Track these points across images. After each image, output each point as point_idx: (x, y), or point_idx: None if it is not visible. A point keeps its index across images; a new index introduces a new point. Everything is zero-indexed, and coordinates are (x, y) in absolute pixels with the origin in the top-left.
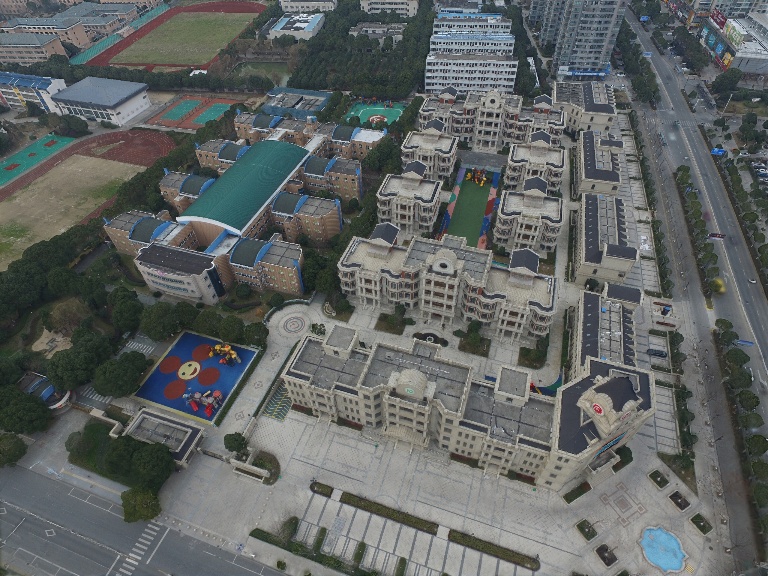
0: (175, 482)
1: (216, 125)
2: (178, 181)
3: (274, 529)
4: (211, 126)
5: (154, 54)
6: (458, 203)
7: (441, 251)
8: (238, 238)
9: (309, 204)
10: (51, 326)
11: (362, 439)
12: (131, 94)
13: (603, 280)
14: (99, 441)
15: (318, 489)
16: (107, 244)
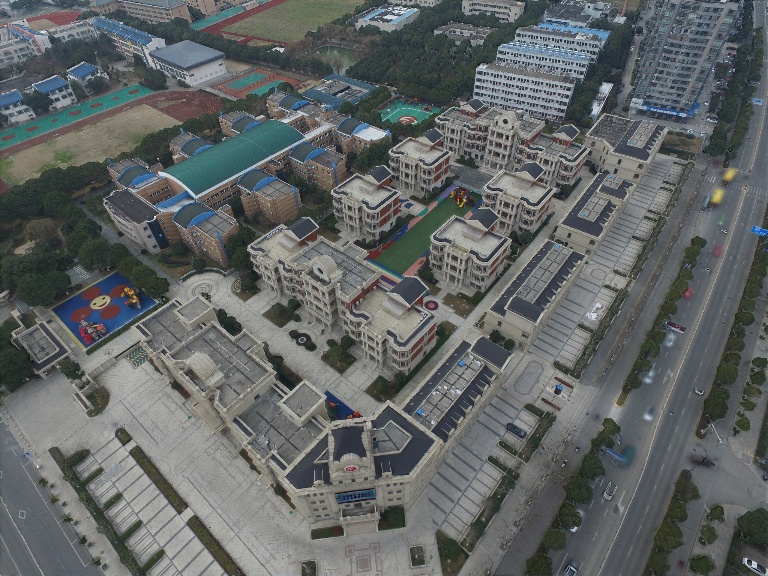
0: (31, 387)
1: (254, 99)
2: (186, 141)
3: (68, 453)
4: (250, 99)
5: (260, 28)
6: (424, 219)
7: (322, 256)
8: (194, 201)
9: (272, 185)
10: (32, 237)
11: (183, 407)
12: (207, 60)
13: (508, 336)
14: (5, 336)
15: (120, 435)
16: (113, 182)
